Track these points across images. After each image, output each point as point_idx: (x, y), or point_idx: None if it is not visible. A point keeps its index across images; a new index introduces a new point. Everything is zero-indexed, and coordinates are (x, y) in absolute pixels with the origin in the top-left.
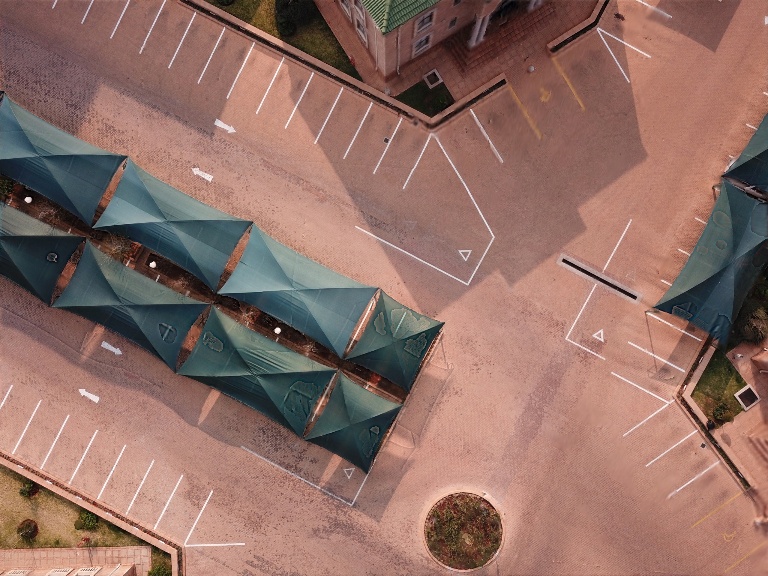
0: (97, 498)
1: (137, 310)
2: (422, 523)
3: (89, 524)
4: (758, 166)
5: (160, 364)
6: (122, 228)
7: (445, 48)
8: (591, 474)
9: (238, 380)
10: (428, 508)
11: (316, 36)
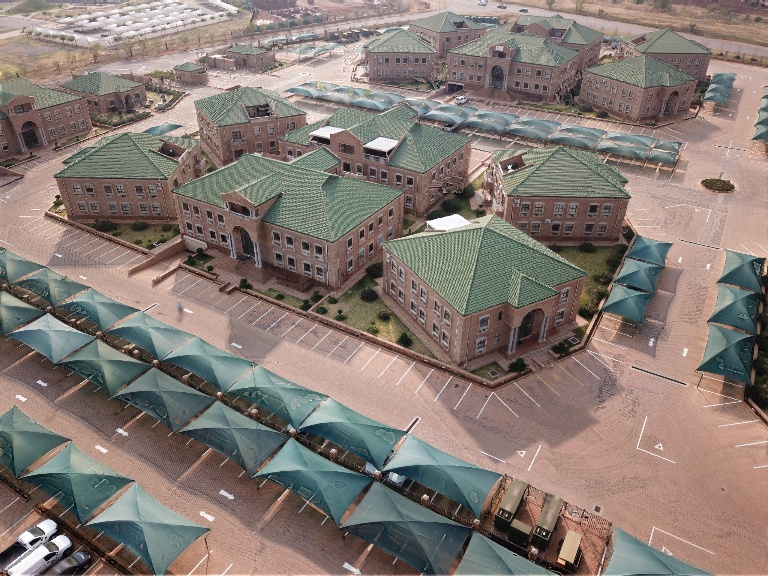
0: None
1: None
2: None
3: None
4: (764, 122)
5: None
6: (567, 129)
7: (651, 119)
8: (758, 176)
9: (618, 148)
10: (700, 181)
11: (610, 118)
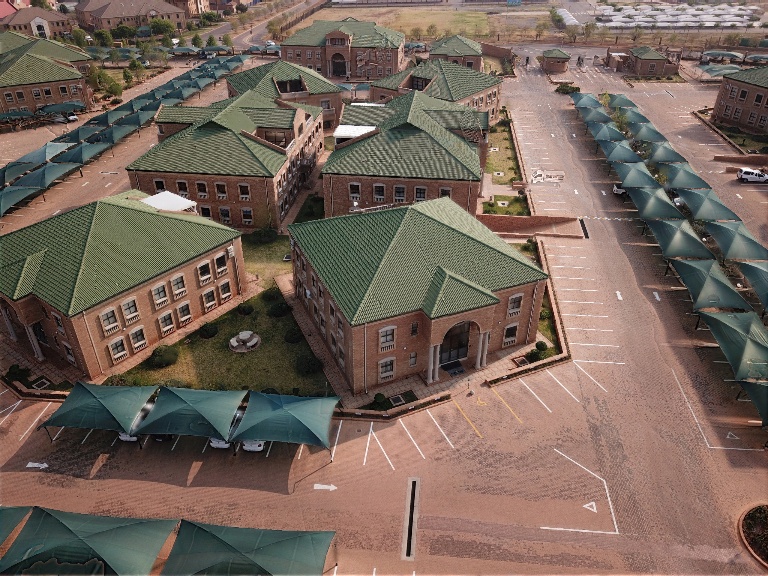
0: (562, 314)
1: (713, 280)
2: (758, 504)
3: (543, 314)
4: None
5: (674, 317)
6: (745, 266)
7: None
8: None
9: (733, 331)
10: None
11: None
